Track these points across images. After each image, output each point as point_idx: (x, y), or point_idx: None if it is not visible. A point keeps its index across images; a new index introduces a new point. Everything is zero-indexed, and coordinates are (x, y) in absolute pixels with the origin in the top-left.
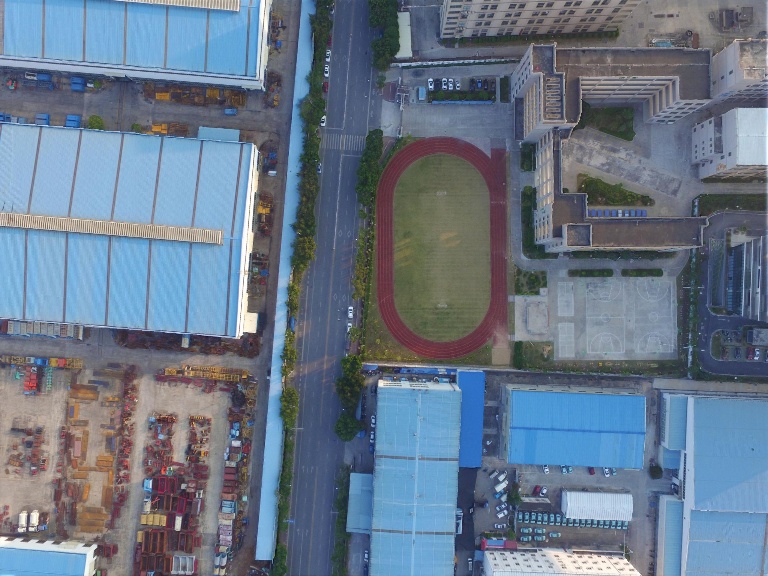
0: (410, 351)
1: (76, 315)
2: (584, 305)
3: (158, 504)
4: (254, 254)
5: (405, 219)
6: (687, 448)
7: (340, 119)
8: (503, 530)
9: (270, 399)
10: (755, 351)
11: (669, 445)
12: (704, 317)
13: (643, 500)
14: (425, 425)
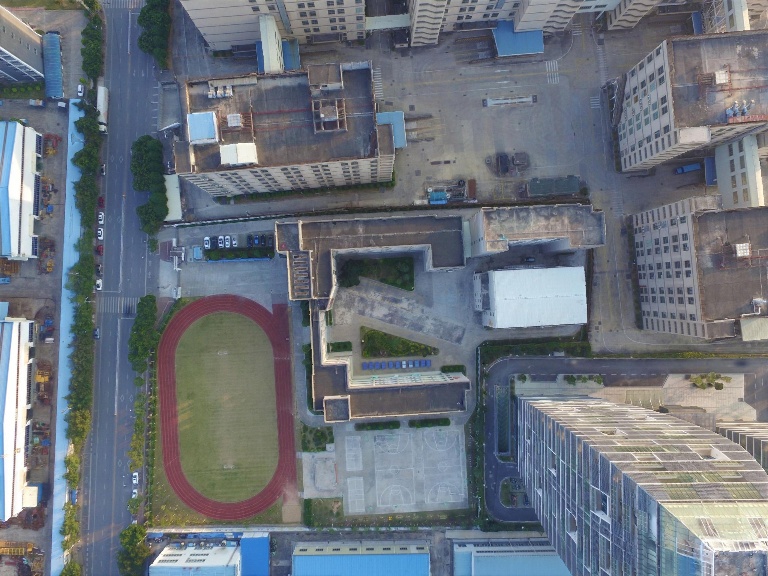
0: (199, 514)
1: None
2: (372, 458)
3: None
4: (34, 424)
5: (188, 380)
6: None
7: (116, 282)
8: None
9: (52, 575)
10: None
11: None
12: (492, 465)
13: None
14: None
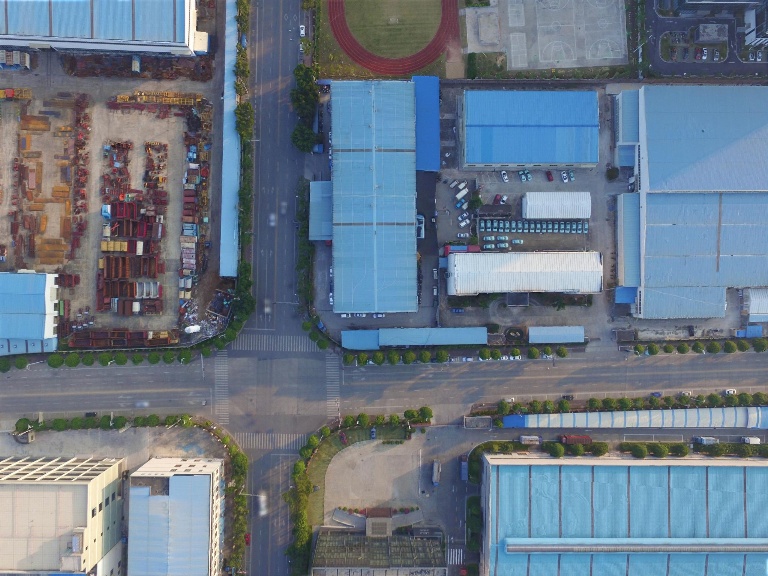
0: (364, 69)
1: (19, 26)
2: (534, 14)
3: (118, 231)
4: None
5: None
6: (640, 138)
7: None
8: (466, 240)
9: (225, 115)
10: (703, 50)
11: (623, 138)
12: (652, 20)
13: (602, 205)
14: (380, 116)
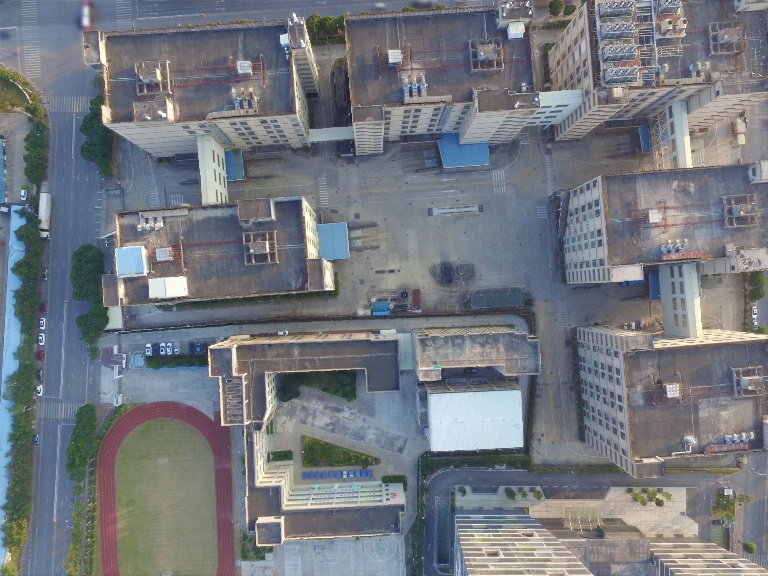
0: None
1: None
2: (311, 568)
3: None
4: None
5: (128, 487)
6: None
7: (57, 388)
8: None
9: None
10: None
11: None
12: None
13: None
14: None
